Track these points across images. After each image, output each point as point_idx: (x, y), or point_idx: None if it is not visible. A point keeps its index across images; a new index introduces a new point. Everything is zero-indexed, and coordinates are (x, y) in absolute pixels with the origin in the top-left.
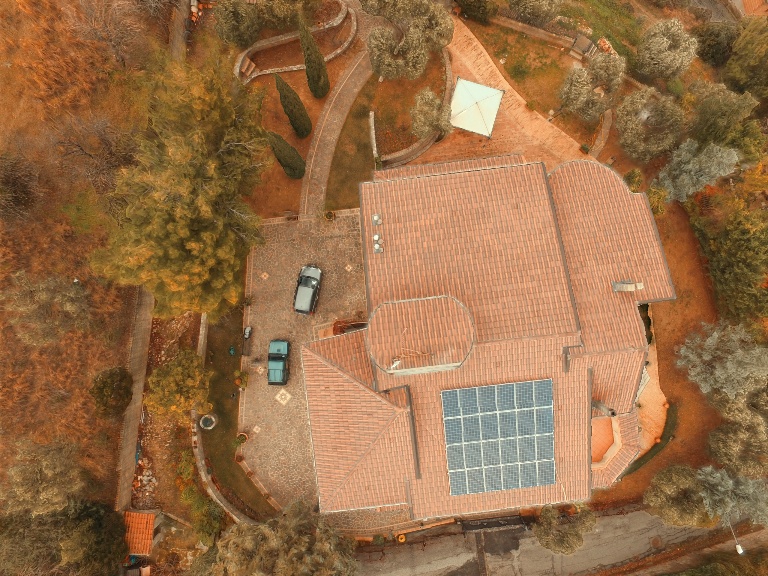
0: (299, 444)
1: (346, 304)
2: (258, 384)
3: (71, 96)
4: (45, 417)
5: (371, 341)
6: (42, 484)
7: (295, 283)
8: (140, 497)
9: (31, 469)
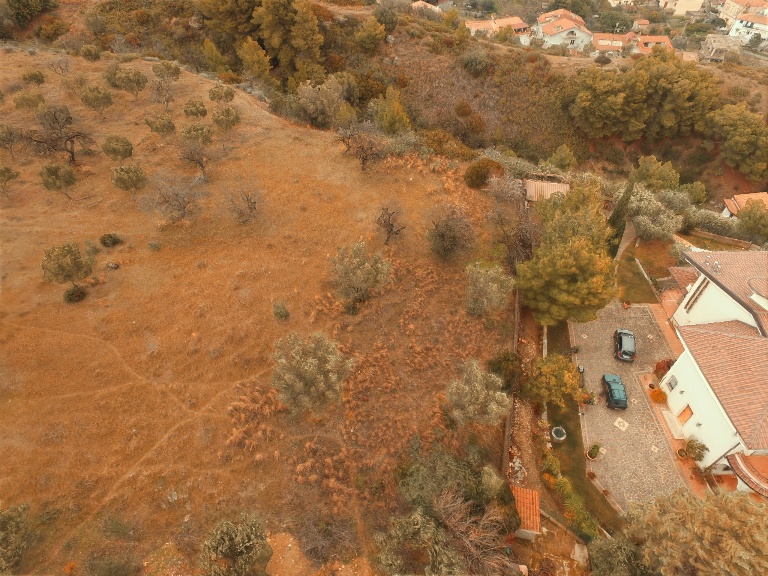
0: (648, 469)
1: (656, 359)
2: (595, 411)
3: (473, 218)
4: (446, 383)
5: (759, 290)
6: (490, 391)
7: (610, 342)
8: (513, 483)
9: (481, 379)
